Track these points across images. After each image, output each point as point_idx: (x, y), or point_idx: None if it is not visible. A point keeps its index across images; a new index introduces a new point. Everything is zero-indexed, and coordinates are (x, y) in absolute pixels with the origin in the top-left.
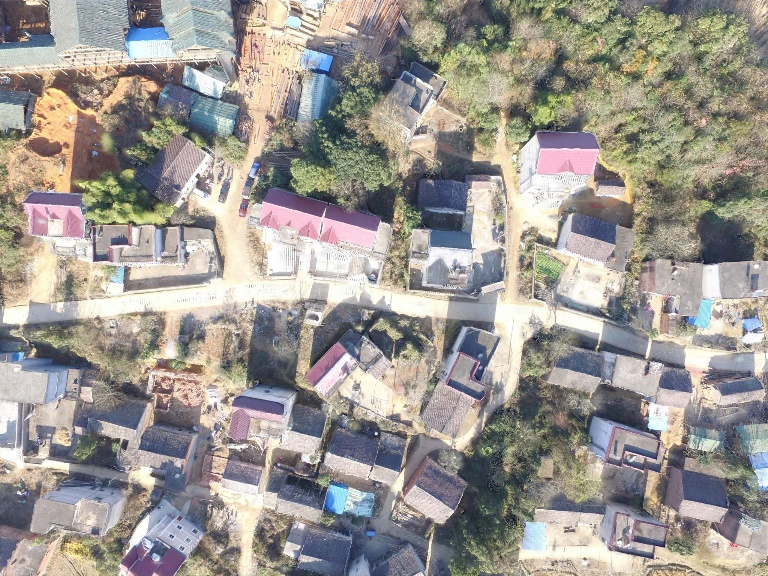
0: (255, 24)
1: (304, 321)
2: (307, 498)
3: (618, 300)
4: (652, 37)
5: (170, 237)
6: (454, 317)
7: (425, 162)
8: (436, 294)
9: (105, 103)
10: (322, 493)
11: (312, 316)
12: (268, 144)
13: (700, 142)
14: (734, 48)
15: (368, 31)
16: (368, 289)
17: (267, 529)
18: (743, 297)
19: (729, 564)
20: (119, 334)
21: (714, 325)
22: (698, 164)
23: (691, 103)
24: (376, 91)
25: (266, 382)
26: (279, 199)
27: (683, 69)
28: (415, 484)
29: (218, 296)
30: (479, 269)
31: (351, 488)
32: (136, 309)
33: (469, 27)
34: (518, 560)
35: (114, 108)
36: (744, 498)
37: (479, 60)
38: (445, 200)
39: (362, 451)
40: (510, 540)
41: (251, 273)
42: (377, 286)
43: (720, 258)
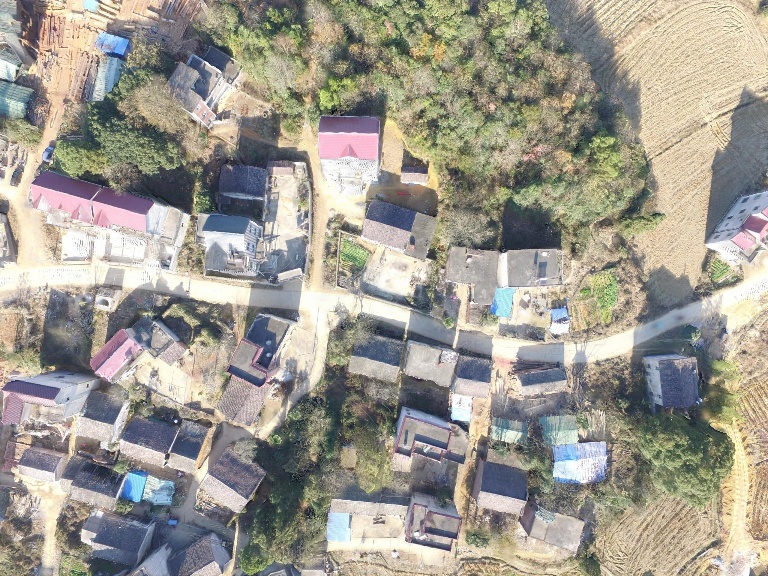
0: (55, 7)
1: (95, 306)
2: (101, 485)
3: (424, 289)
4: (440, 21)
5: None
6: (256, 304)
7: (227, 147)
8: (234, 281)
9: None
10: (118, 481)
11: (101, 301)
12: (60, 128)
13: (489, 128)
14: (534, 33)
15: (170, 15)
16: (165, 275)
17: (69, 517)
18: (530, 285)
19: (539, 558)
20: None
21: (521, 315)
22: (495, 151)
23: (479, 88)
24: (156, 74)
25: (66, 368)
26: (49, 181)
27: (472, 54)
28: (208, 472)
29: (12, 281)
30: (283, 256)
31: (150, 476)
32: None
33: None
34: (326, 551)
35: None
36: (540, 490)
37: (261, 43)
38: (241, 186)
39: (157, 438)
40: (313, 531)
41: (45, 258)
42: (174, 272)
43: (527, 247)
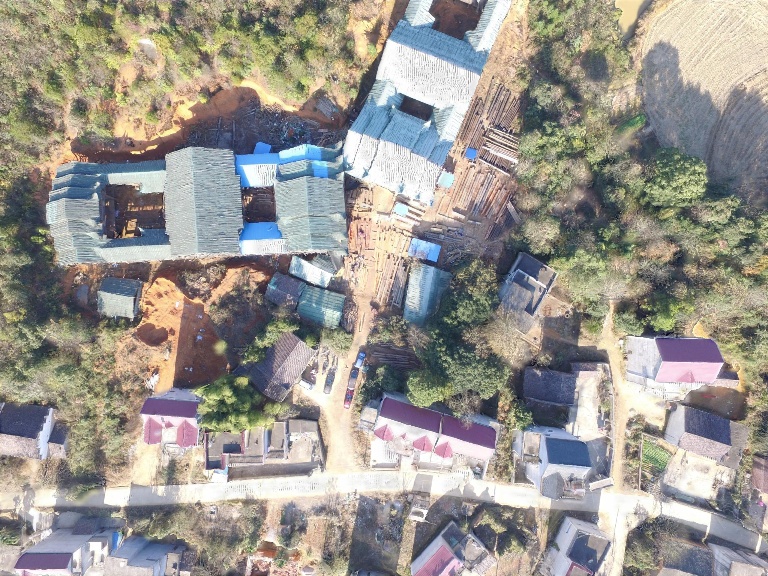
0: (361, 209)
1: (408, 517)
2: None
3: (728, 492)
4: None
5: (276, 431)
6: (558, 507)
7: (530, 349)
8: None
9: (213, 294)
10: None
11: (417, 513)
12: (375, 336)
13: None
14: None
15: (475, 216)
16: (472, 481)
17: None
18: None
19: None
20: (219, 519)
21: None
22: None
23: None
24: (492, 296)
25: (364, 569)
26: (395, 412)
27: None
28: None
29: (320, 486)
30: None
31: None
32: (237, 496)
33: (577, 211)
34: None
35: (222, 299)
36: None
37: (598, 265)
38: (553, 393)
39: None
40: None
41: (354, 463)
42: None
43: None
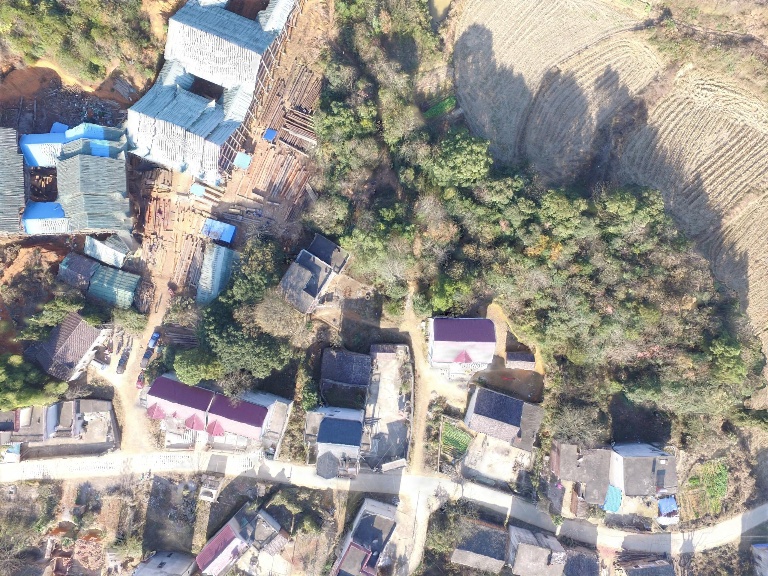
0: (160, 189)
1: (199, 497)
2: None
3: (528, 475)
4: (556, 221)
5: (65, 411)
6: (357, 489)
7: (330, 330)
8: None
9: (5, 274)
10: None
11: (206, 493)
12: (167, 316)
13: (606, 330)
14: (648, 225)
15: (274, 197)
16: (267, 462)
17: None
18: (648, 494)
19: None
20: (18, 499)
21: (628, 504)
22: (608, 346)
23: (596, 290)
24: (269, 276)
25: (165, 549)
26: (164, 390)
27: (589, 254)
28: None
29: (115, 466)
30: (384, 440)
31: None
32: (35, 476)
33: (378, 193)
34: None
35: (14, 279)
36: None
37: (375, 245)
38: (346, 374)
39: None
40: None
41: (149, 444)
42: (276, 459)
43: (635, 435)
